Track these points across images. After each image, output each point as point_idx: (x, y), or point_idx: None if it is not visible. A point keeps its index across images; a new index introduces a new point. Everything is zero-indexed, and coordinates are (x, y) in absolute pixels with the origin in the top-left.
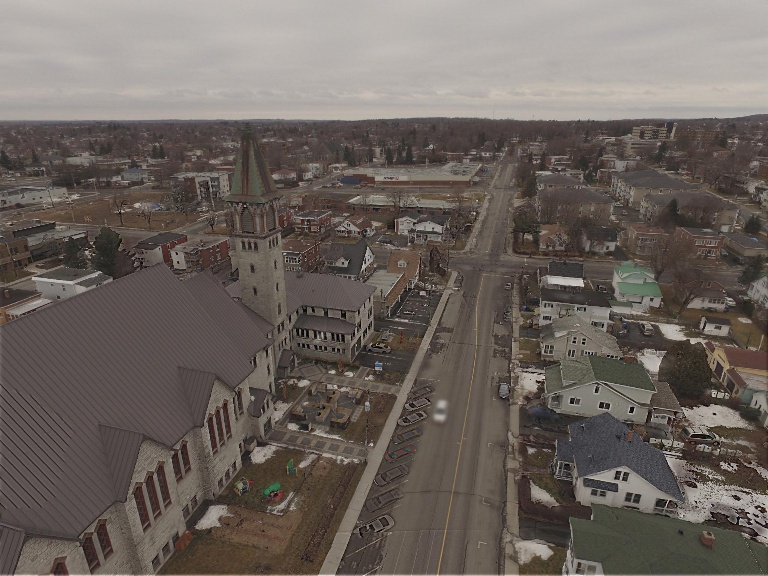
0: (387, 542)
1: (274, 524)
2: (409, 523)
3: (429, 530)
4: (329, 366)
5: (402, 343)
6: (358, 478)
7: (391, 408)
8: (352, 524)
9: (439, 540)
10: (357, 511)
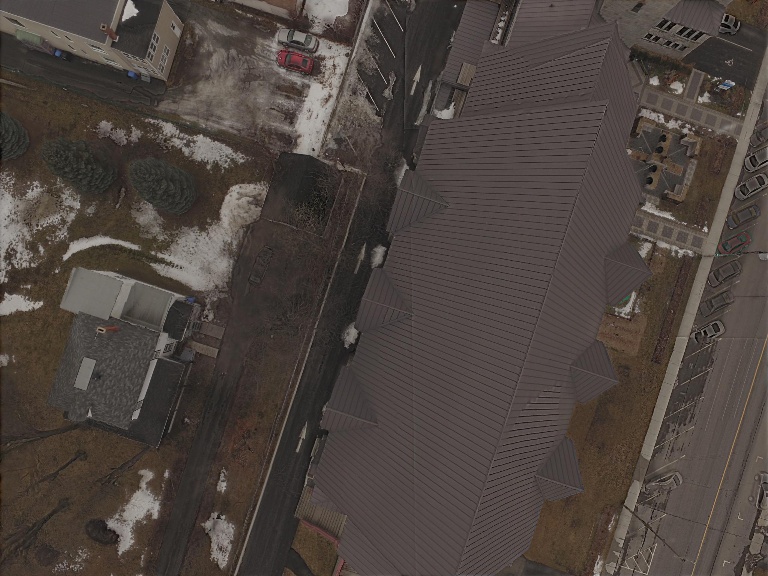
0: (718, 348)
1: (625, 328)
2: (737, 330)
3: (753, 339)
4: (650, 66)
5: (754, 3)
6: (693, 277)
7: (729, 166)
8: (689, 329)
9: (760, 348)
10: (693, 316)
